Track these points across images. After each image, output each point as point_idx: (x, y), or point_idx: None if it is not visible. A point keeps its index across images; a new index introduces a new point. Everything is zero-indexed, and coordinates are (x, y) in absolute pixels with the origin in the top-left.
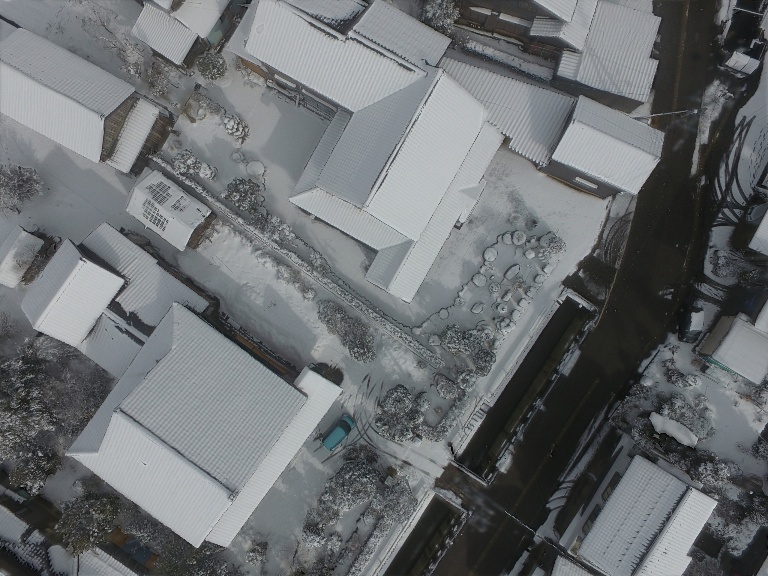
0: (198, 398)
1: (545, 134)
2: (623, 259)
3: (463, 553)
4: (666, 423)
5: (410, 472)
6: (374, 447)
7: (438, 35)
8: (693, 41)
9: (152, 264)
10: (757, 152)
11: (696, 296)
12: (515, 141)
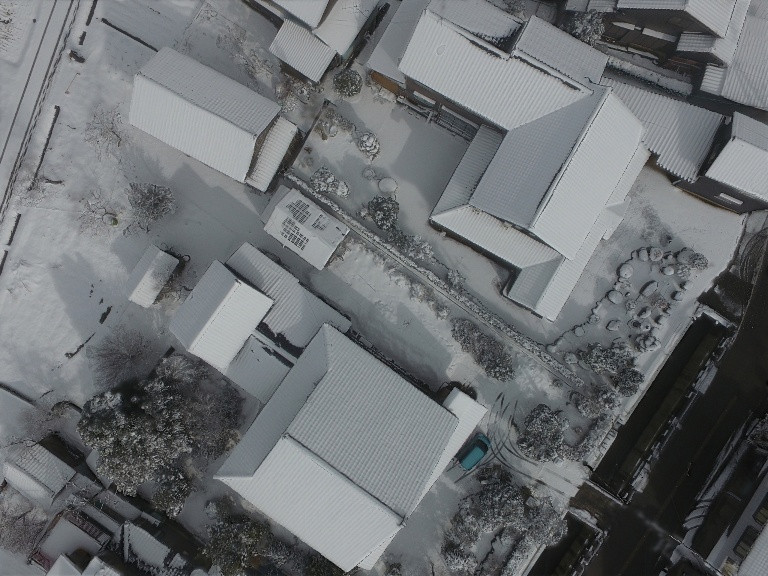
0: (359, 421)
1: (693, 150)
2: (760, 275)
3: (599, 574)
4: None
5: (544, 492)
6: (508, 466)
7: (595, 52)
8: None
9: (294, 284)
10: None
11: None
12: (663, 158)
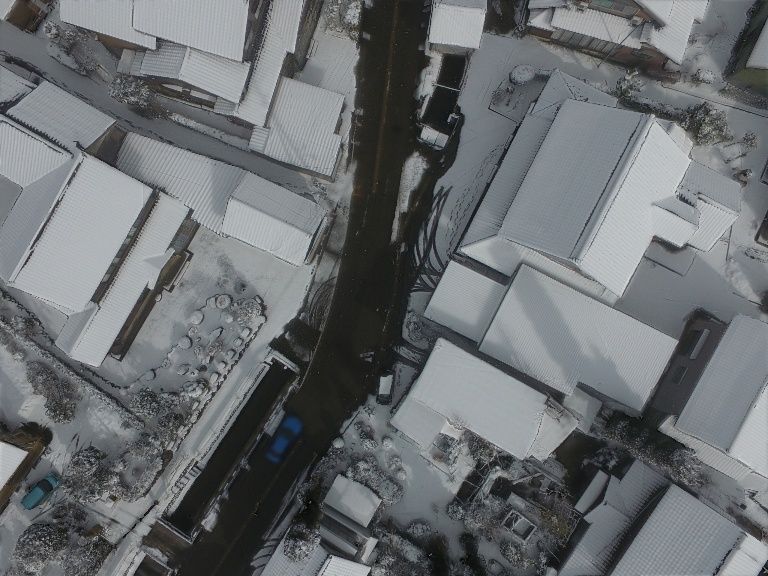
0: None
1: None
2: (327, 322)
3: None
4: (350, 485)
5: (118, 530)
6: (82, 505)
7: (101, 116)
8: (393, 115)
9: None
10: (453, 221)
11: (395, 359)
12: (196, 213)
